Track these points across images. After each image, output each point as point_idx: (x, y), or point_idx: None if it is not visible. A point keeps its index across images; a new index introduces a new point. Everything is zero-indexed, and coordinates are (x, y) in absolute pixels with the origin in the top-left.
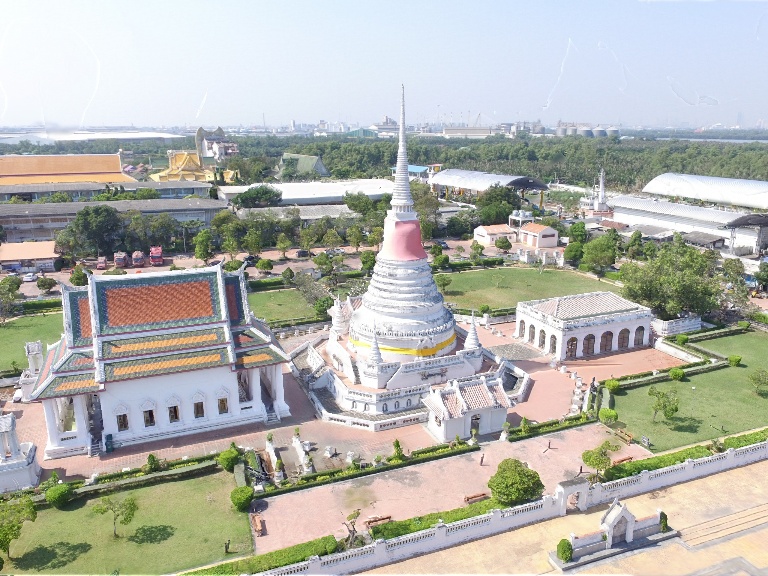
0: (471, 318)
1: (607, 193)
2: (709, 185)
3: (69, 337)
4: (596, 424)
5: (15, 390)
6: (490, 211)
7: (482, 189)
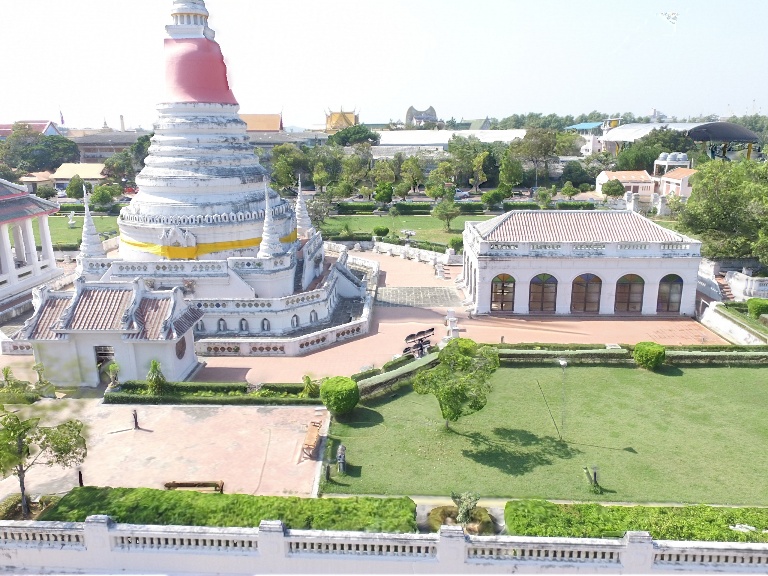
0: (430, 254)
1: None
2: None
3: None
4: (315, 407)
5: None
6: (628, 154)
7: None
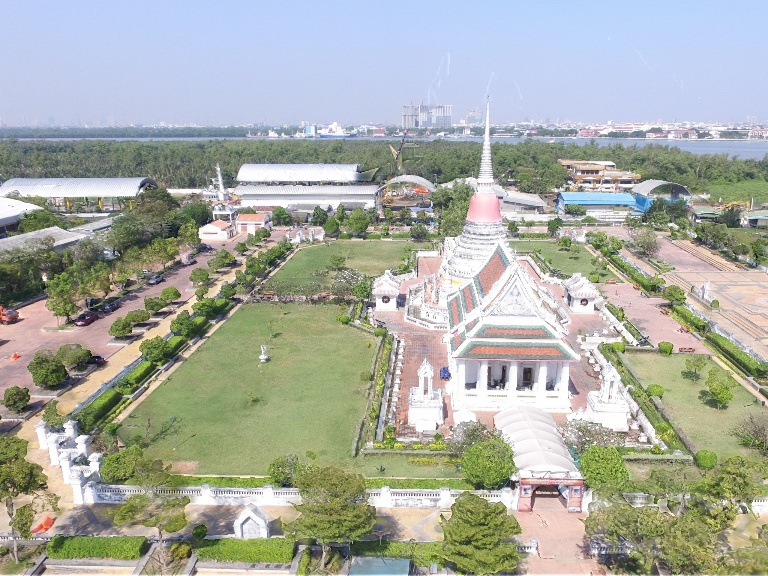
0: (406, 275)
1: (226, 185)
2: (294, 170)
3: (540, 312)
4: (594, 284)
5: (398, 432)
6: (194, 210)
7: (107, 195)
